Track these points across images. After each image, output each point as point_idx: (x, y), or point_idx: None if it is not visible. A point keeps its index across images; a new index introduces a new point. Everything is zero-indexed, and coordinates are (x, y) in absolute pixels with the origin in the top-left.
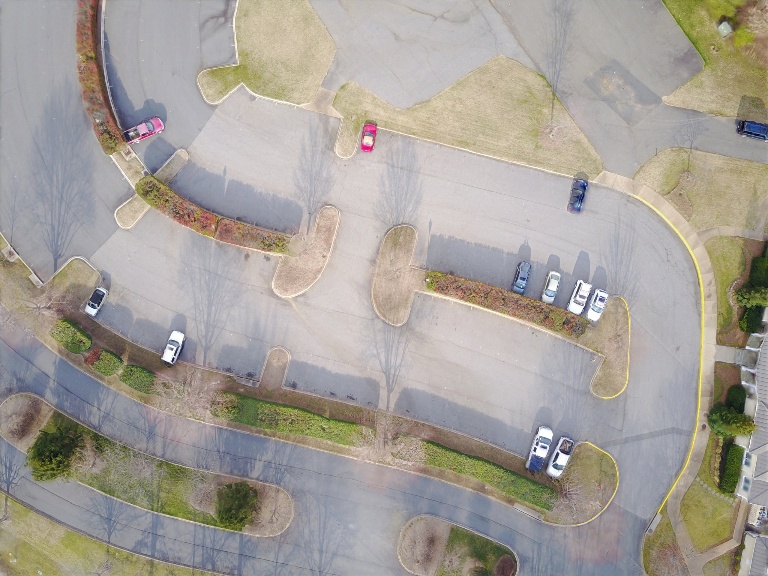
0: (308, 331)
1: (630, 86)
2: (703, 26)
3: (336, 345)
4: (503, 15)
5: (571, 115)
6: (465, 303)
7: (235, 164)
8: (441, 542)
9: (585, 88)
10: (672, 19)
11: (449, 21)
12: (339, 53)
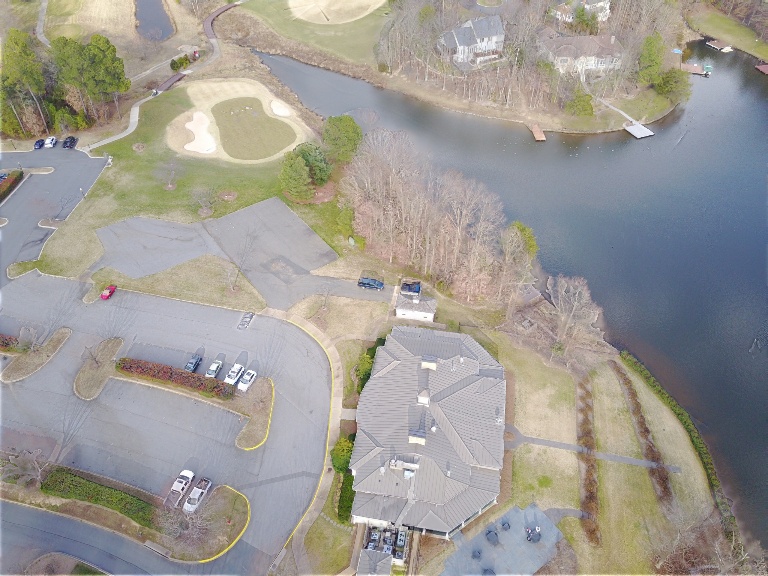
0: (14, 404)
1: (289, 266)
2: (340, 241)
3: (32, 414)
4: (215, 238)
5: (249, 280)
6: (146, 384)
7: (10, 307)
8: None
9: (260, 268)
10: (320, 238)
11: (180, 240)
12: (105, 254)
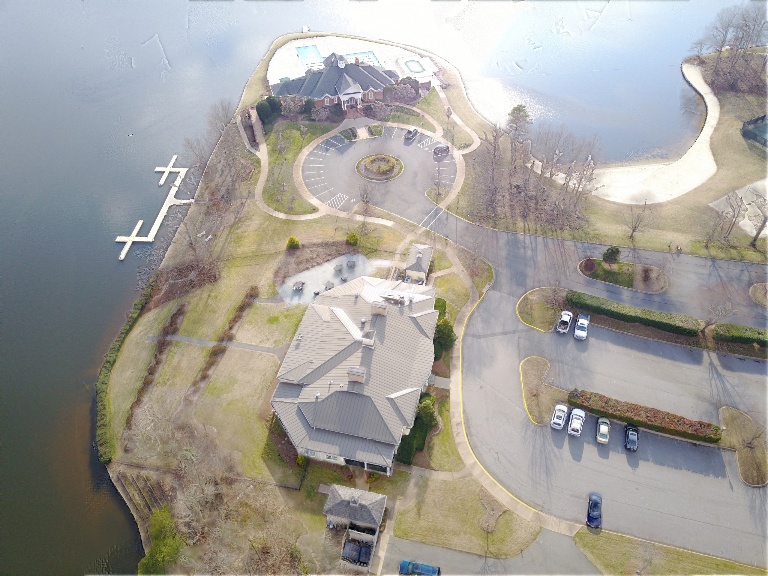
0: None
1: None
2: None
3: None
4: None
5: None
6: None
7: None
8: (638, 279)
9: None
10: None
11: None
12: None
